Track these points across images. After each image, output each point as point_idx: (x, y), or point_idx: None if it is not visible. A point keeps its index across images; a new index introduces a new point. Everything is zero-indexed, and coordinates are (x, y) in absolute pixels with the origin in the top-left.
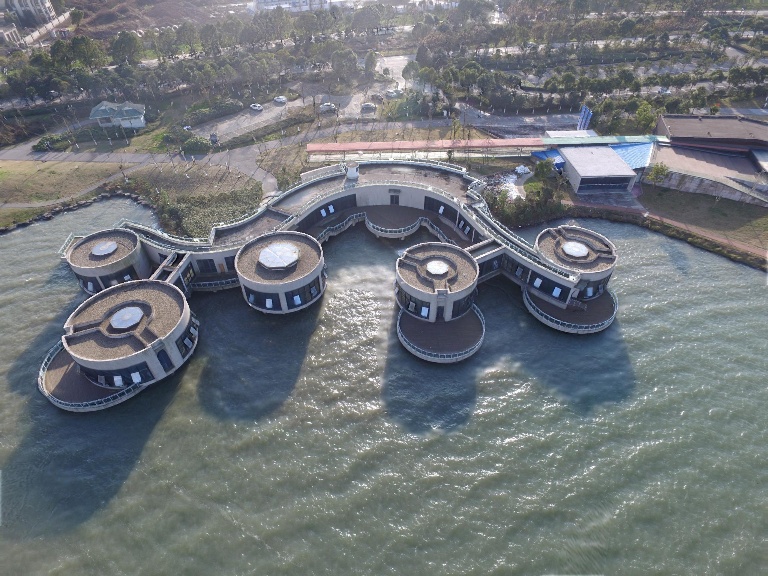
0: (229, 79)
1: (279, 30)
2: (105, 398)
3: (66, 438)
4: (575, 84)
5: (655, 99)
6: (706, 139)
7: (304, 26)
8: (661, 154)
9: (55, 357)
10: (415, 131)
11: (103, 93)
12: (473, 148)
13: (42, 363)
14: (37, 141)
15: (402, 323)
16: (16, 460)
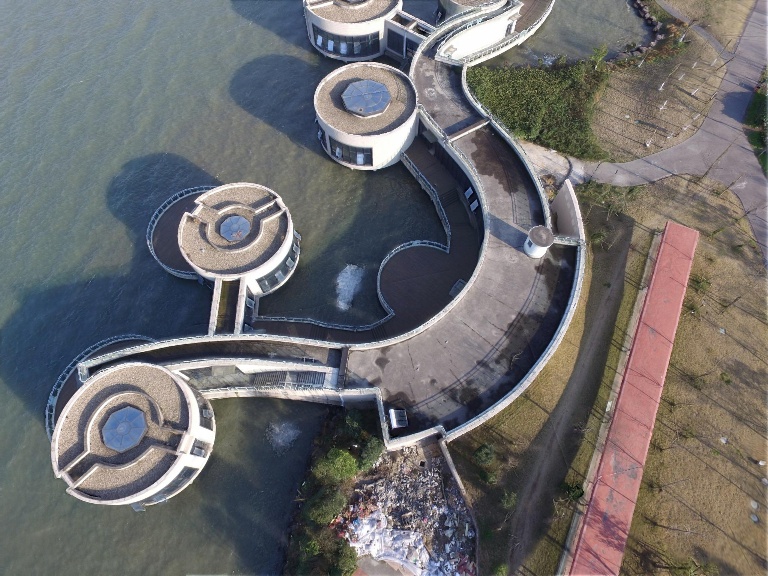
0: None
1: None
2: None
3: None
4: None
5: None
6: None
7: None
8: None
9: None
10: None
11: None
12: None
13: None
14: None
15: None
16: None
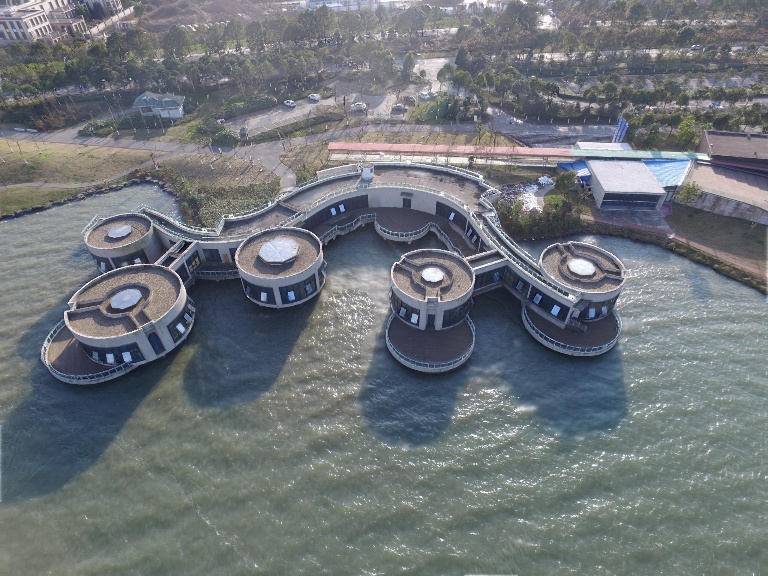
0: (267, 75)
1: (323, 29)
2: (97, 373)
3: (57, 407)
4: (617, 94)
5: (704, 114)
6: (751, 159)
7: (348, 25)
8: (698, 173)
9: (61, 330)
10: (441, 135)
11: (149, 84)
12: (497, 155)
13: (48, 335)
14: (83, 126)
15: (392, 328)
16: (10, 423)
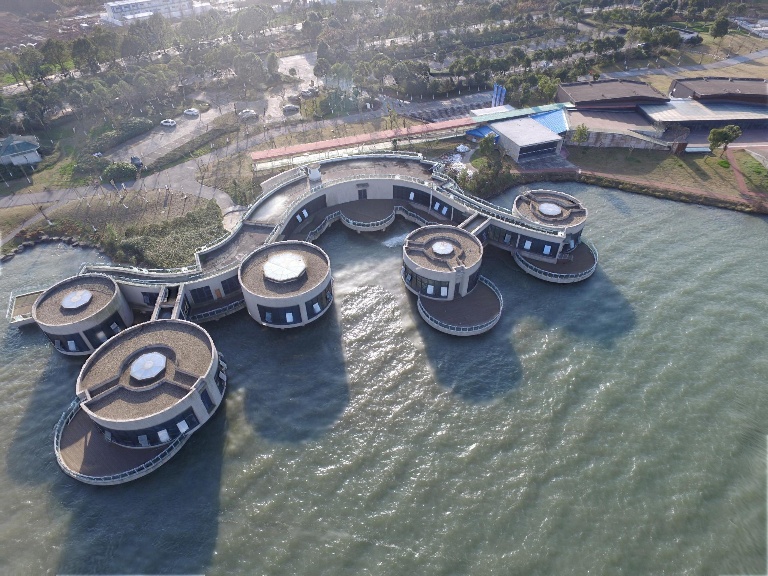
0: (128, 96)
1: (160, 39)
2: (154, 458)
3: (125, 514)
4: (477, 65)
5: (543, 72)
6: (603, 101)
7: (188, 33)
8: (573, 118)
9: (63, 433)
10: (348, 126)
11: None
12: (411, 135)
13: (53, 443)
14: None
15: (424, 307)
16: (71, 557)
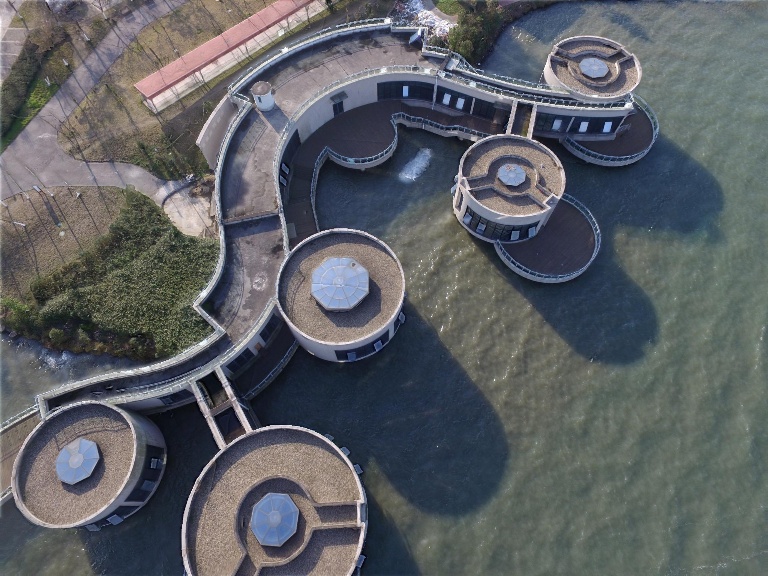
0: None
1: None
2: None
3: None
4: None
5: None
6: None
7: None
8: None
9: None
10: None
11: None
12: None
13: None
14: None
15: None
16: None
